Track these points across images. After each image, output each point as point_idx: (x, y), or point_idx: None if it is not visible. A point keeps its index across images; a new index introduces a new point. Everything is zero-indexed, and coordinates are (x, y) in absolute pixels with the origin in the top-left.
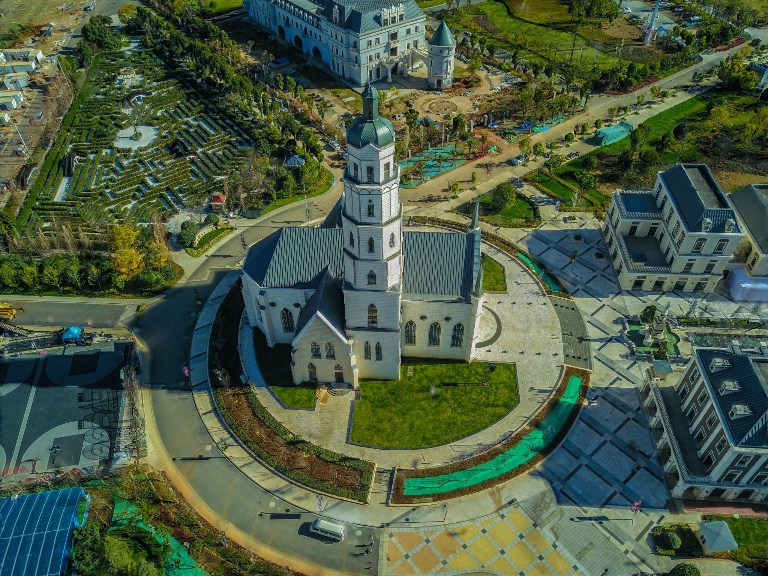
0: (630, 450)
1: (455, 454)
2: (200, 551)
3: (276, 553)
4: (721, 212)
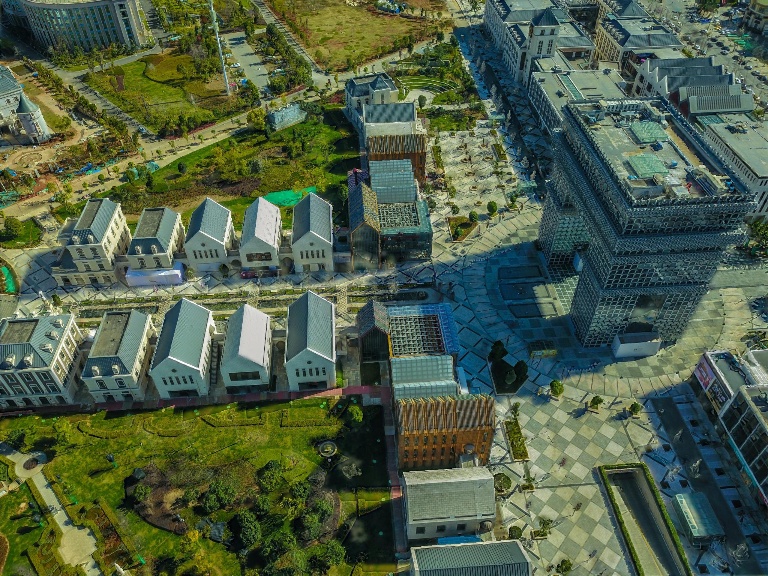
0: None
1: None
2: None
3: None
4: (83, 231)
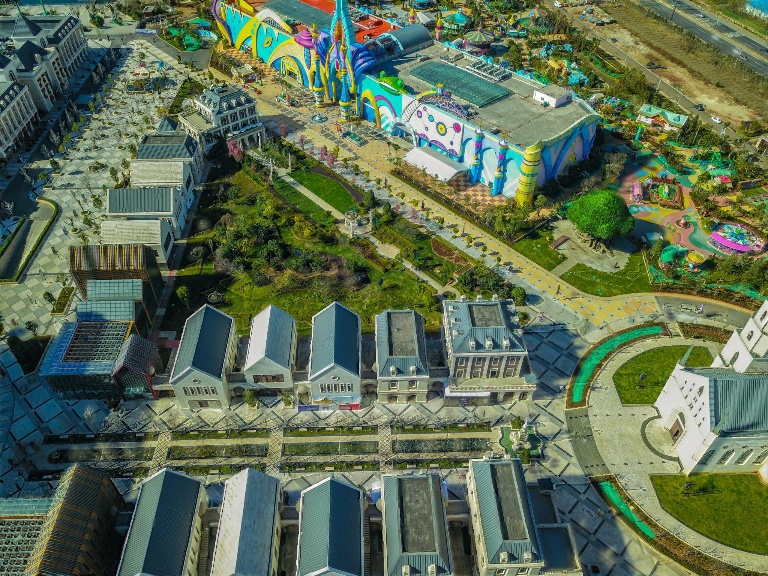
0: (538, 360)
1: (641, 346)
2: (742, 279)
3: (707, 301)
4: None
